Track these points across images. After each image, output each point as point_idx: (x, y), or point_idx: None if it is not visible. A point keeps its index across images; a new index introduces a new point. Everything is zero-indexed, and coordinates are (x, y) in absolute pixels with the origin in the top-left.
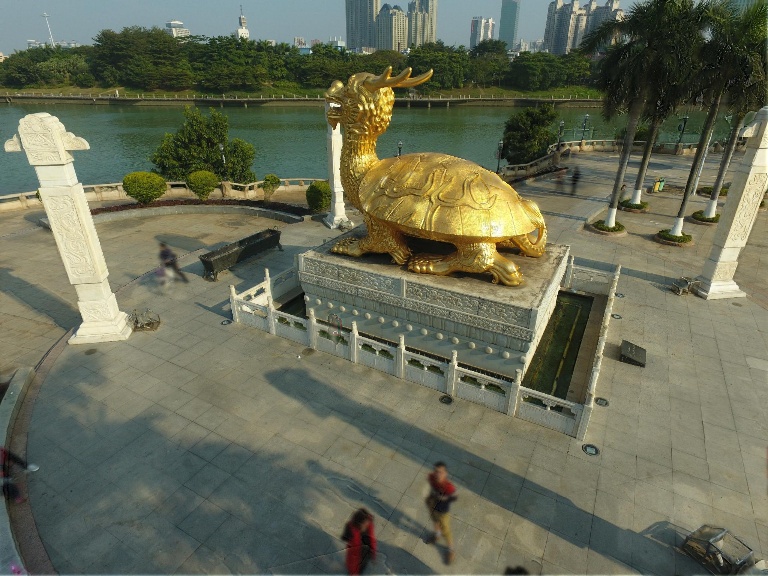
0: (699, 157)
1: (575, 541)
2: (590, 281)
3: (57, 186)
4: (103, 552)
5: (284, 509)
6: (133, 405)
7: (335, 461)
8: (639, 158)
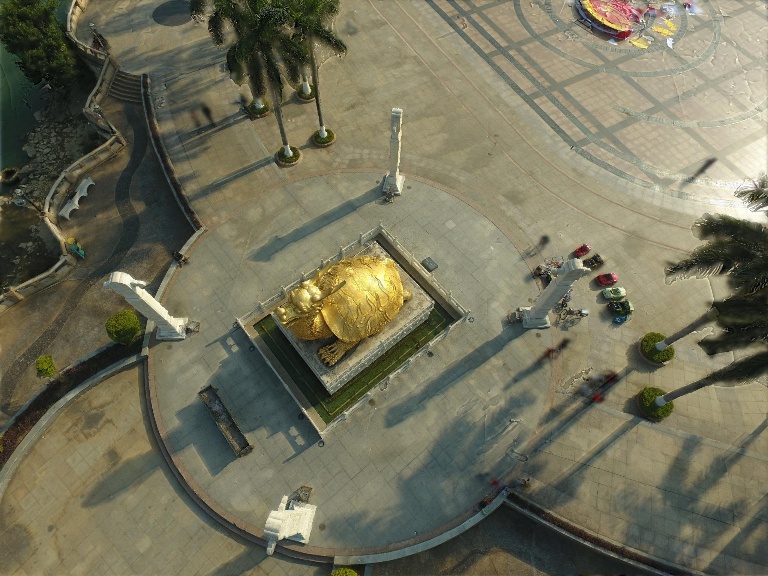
0: (318, 91)
1: (501, 349)
2: (371, 235)
3: (288, 524)
4: (464, 496)
5: (465, 433)
6: (385, 495)
7: (449, 410)
8: None
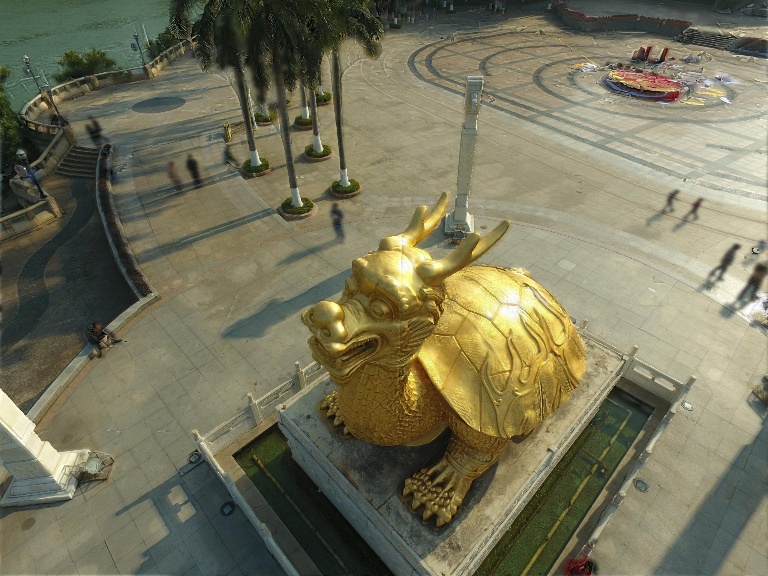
0: (340, 111)
1: None
2: None
3: None
4: None
5: None
6: None
7: None
8: (129, 96)
